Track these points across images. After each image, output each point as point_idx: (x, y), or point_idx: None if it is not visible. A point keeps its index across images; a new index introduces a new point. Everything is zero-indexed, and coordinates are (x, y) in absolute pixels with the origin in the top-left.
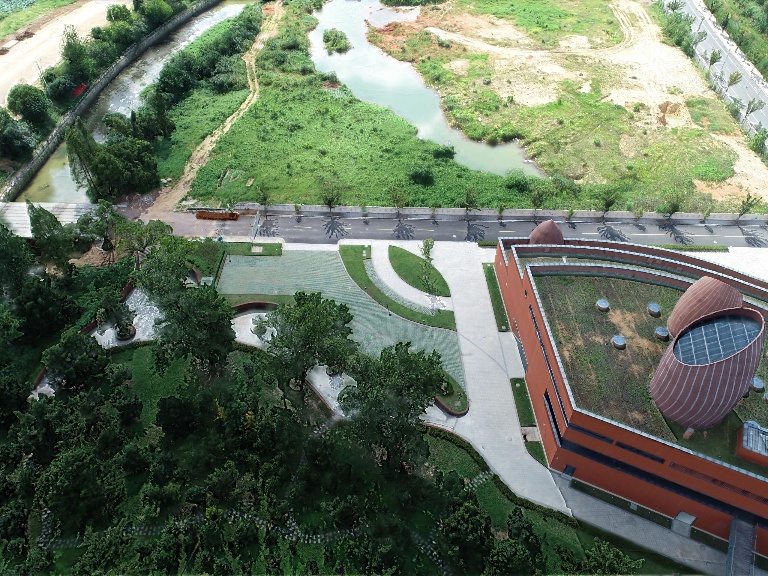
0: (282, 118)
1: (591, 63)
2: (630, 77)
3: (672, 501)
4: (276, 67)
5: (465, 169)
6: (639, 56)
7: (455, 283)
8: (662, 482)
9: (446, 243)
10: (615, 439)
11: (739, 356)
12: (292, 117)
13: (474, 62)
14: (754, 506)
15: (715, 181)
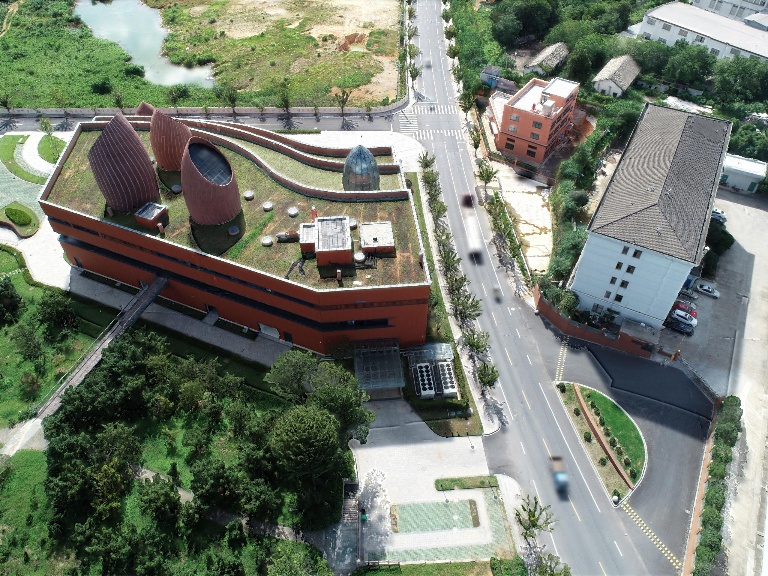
0: (13, 49)
1: (313, 6)
2: (338, 16)
3: (129, 272)
4: (33, 13)
5: (146, 83)
6: (359, 1)
7: None
8: (118, 257)
9: None
10: (70, 222)
11: (99, 141)
12: (22, 48)
13: (213, 7)
14: (152, 259)
15: (349, 88)
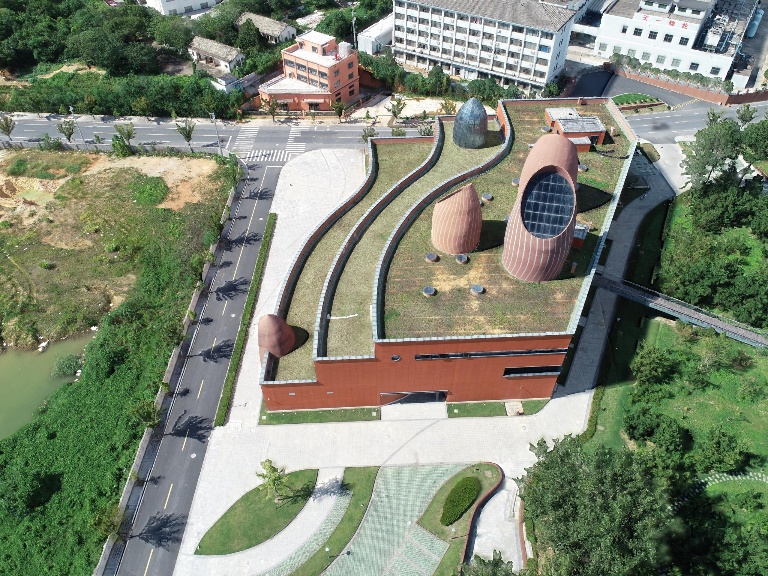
0: None
1: None
2: None
3: None
4: None
5: (35, 426)
6: None
7: (293, 462)
8: None
9: (207, 468)
10: None
11: None
12: None
13: None
14: None
15: (168, 194)
